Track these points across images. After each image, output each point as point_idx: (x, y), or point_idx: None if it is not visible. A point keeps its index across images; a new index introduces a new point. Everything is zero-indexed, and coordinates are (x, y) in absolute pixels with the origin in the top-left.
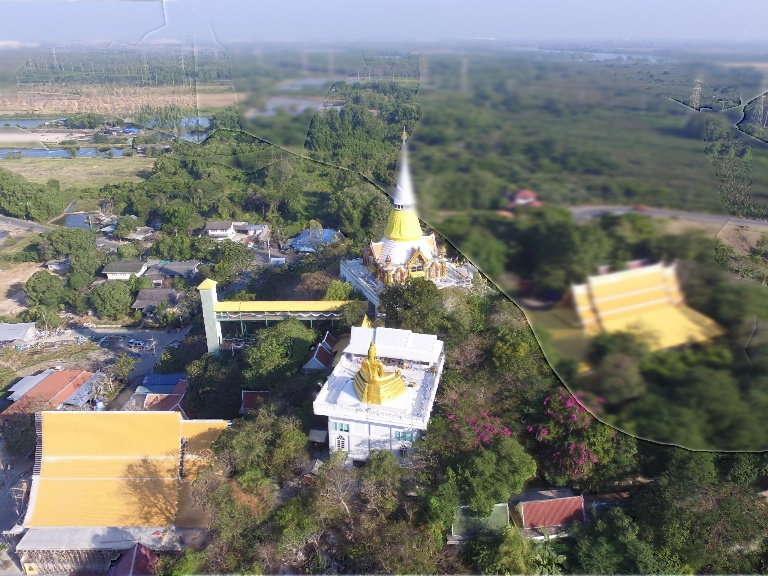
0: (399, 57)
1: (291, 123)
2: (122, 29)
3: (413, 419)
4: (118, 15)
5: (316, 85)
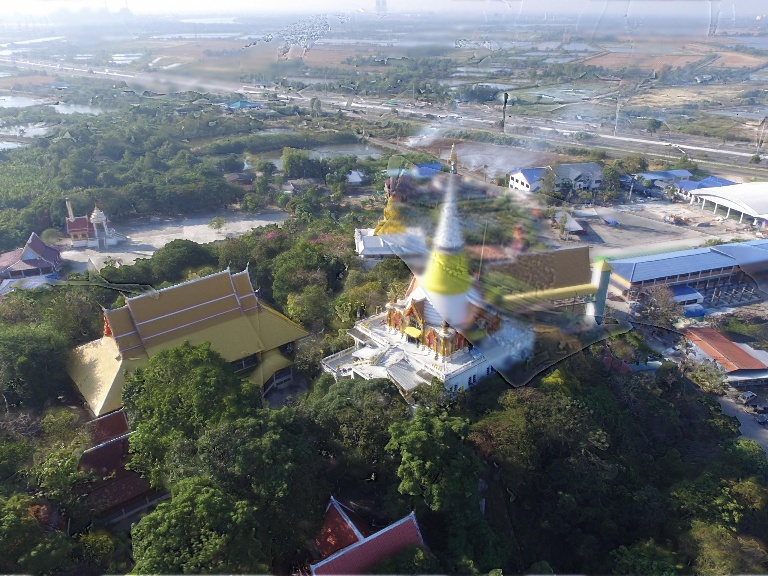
0: (330, 14)
1: (344, 22)
2: (364, 10)
3: (363, 230)
4: (364, 8)
5: (340, 17)
